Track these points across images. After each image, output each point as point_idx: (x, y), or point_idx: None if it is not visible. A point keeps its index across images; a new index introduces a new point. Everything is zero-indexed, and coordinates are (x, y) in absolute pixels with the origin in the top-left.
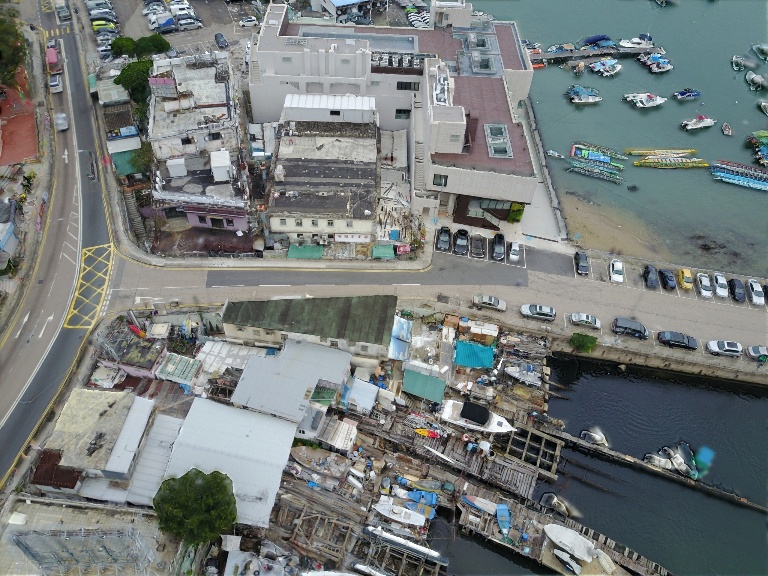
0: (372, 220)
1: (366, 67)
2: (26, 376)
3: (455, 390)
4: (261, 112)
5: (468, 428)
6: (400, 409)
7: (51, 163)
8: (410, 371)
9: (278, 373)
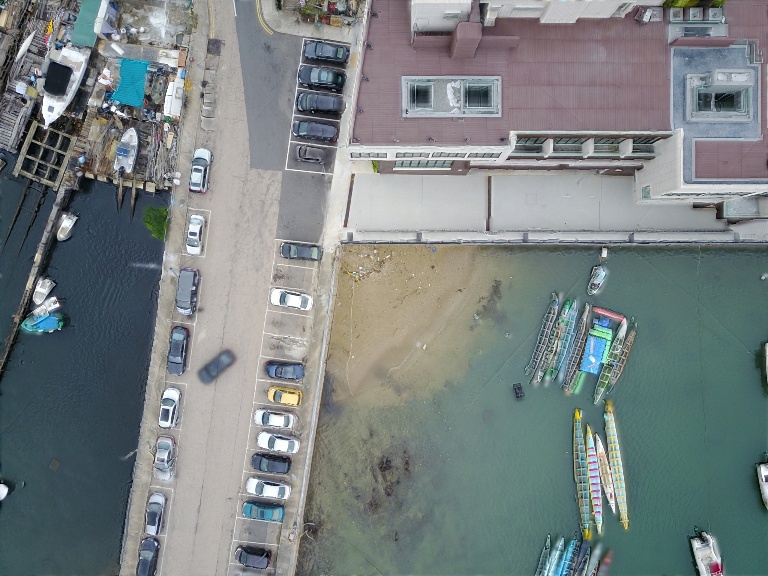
0: None
1: None
2: None
3: None
4: None
5: None
6: None
7: None
8: None
9: None
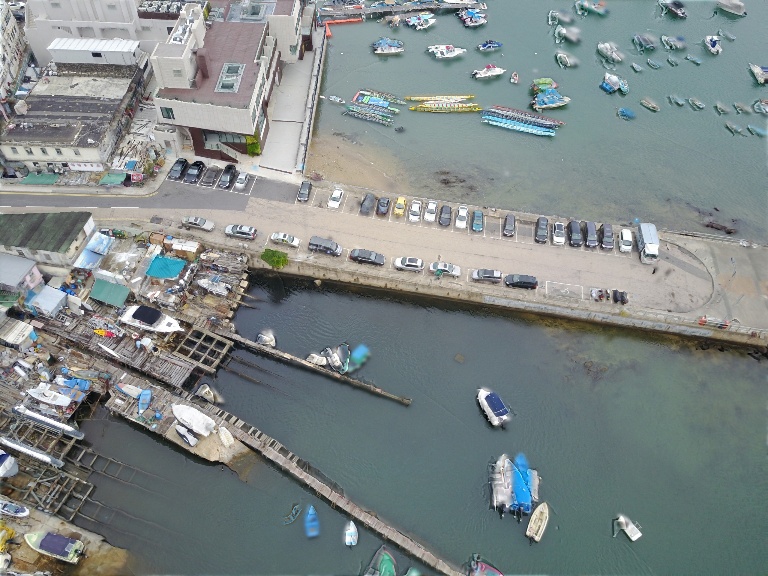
0: (95, 148)
1: (132, 12)
2: None
3: (146, 298)
4: (43, 57)
5: (144, 329)
6: (88, 314)
7: None
8: (100, 280)
9: None
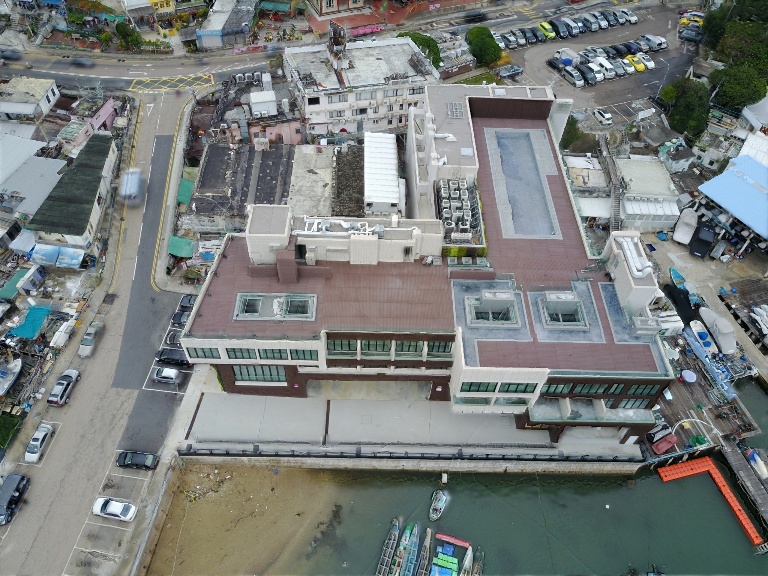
0: None
1: None
2: (98, 74)
3: None
4: None
5: None
6: None
7: (315, 42)
8: None
9: (42, 175)
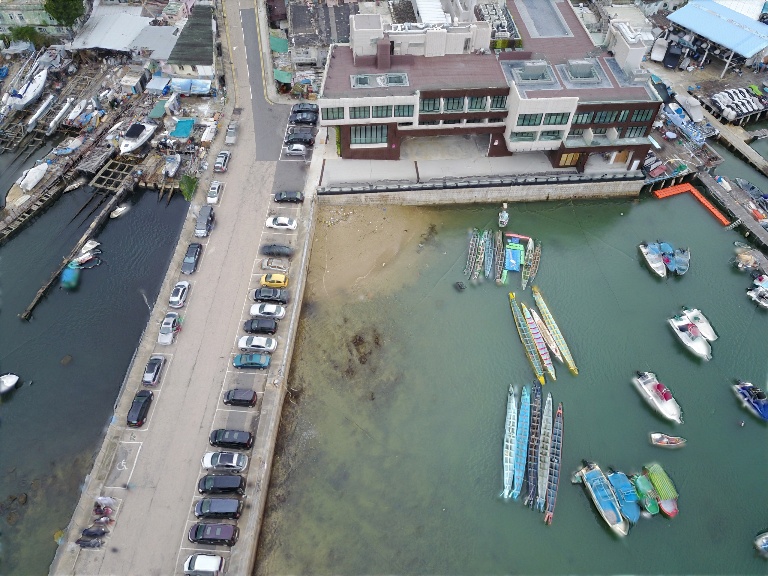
0: None
1: (472, 3)
2: None
3: None
4: None
5: None
6: None
7: None
8: None
9: (162, 36)
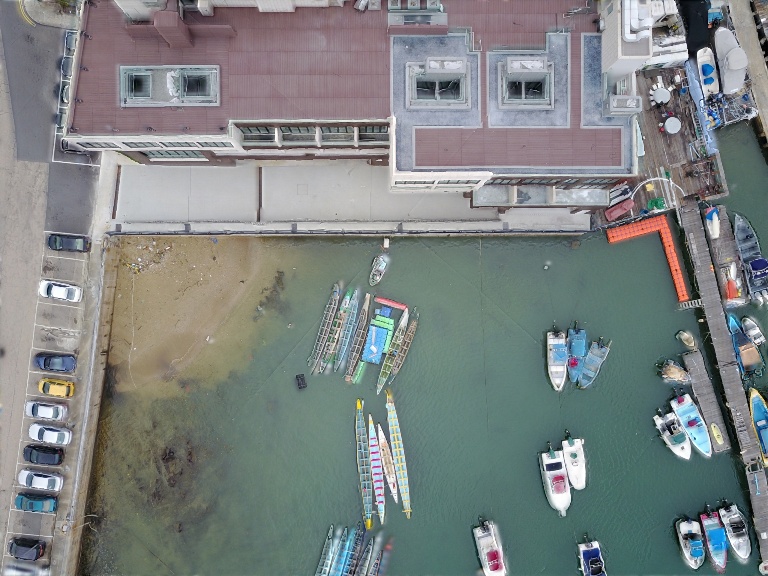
0: None
1: None
2: None
3: None
4: None
5: None
6: None
7: None
8: None
9: None
